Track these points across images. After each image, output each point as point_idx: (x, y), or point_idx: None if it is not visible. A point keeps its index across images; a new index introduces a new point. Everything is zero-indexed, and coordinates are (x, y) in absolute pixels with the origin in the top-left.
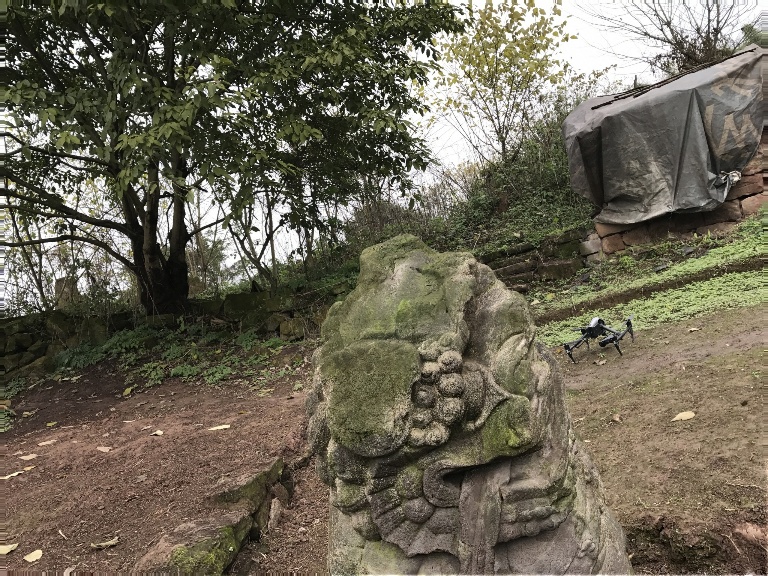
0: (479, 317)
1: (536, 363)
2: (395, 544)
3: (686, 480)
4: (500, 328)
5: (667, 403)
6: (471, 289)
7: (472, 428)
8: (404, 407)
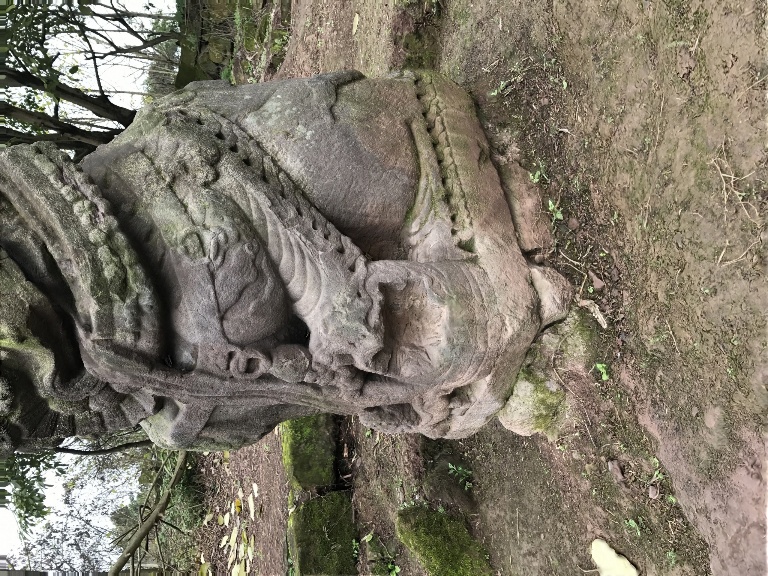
0: None
1: None
2: None
3: None
4: None
5: None
6: None
7: (5, 354)
8: None
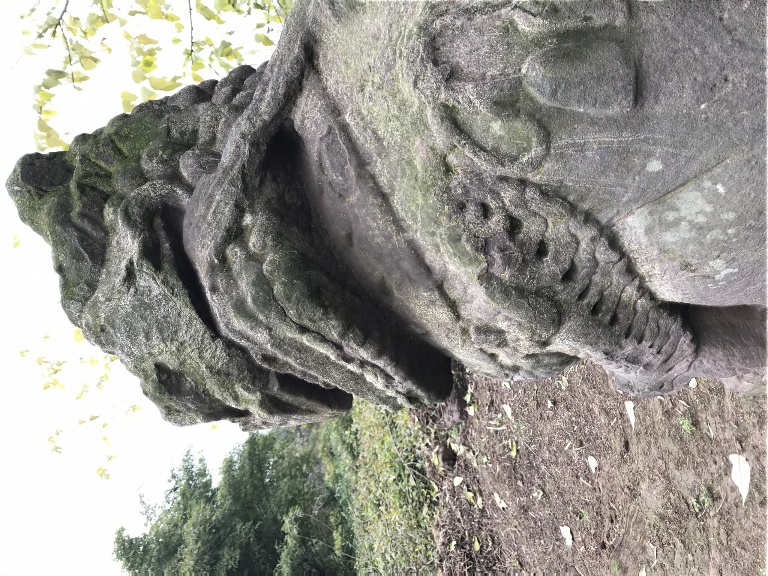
0: None
1: None
2: None
3: None
4: None
5: None
6: None
7: None
8: None
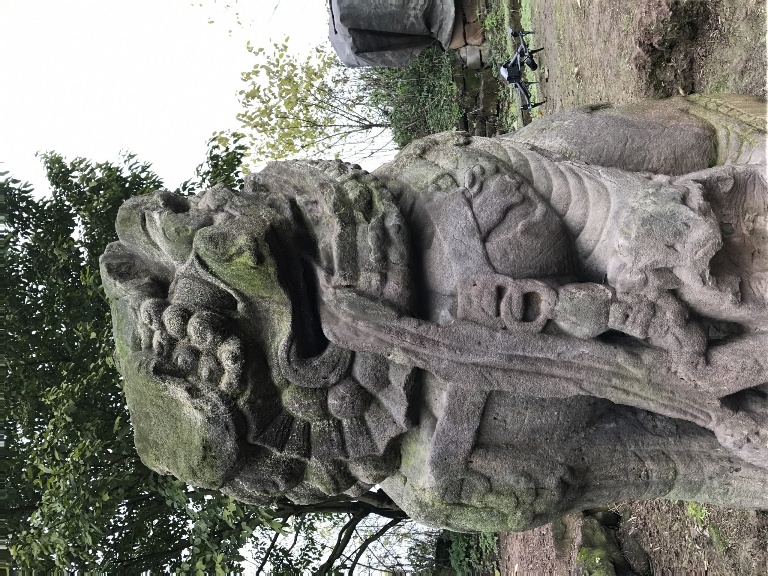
0: (137, 260)
1: None
2: (389, 442)
3: (620, 3)
4: (137, 240)
5: (569, 8)
6: None
7: (242, 306)
8: (179, 392)
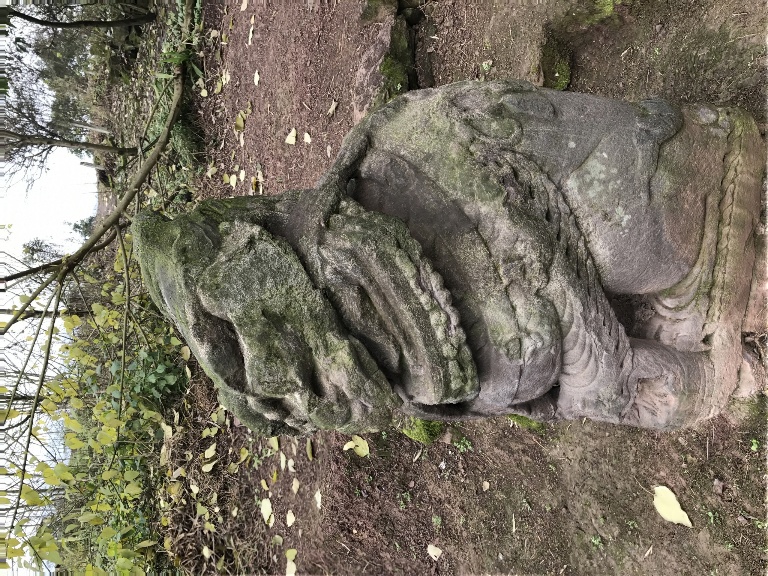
0: None
1: (331, 371)
2: None
3: None
4: None
5: None
6: (217, 373)
7: None
8: None
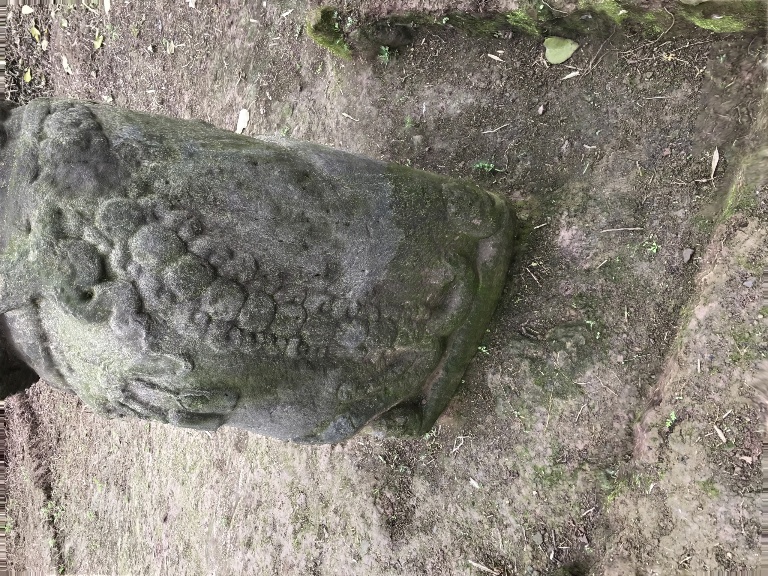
0: None
1: None
2: None
3: None
4: None
5: None
6: None
7: None
8: None
